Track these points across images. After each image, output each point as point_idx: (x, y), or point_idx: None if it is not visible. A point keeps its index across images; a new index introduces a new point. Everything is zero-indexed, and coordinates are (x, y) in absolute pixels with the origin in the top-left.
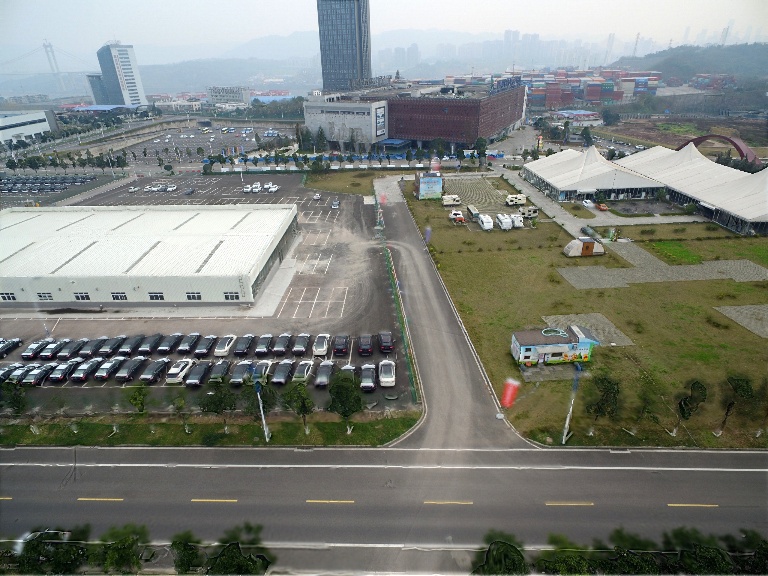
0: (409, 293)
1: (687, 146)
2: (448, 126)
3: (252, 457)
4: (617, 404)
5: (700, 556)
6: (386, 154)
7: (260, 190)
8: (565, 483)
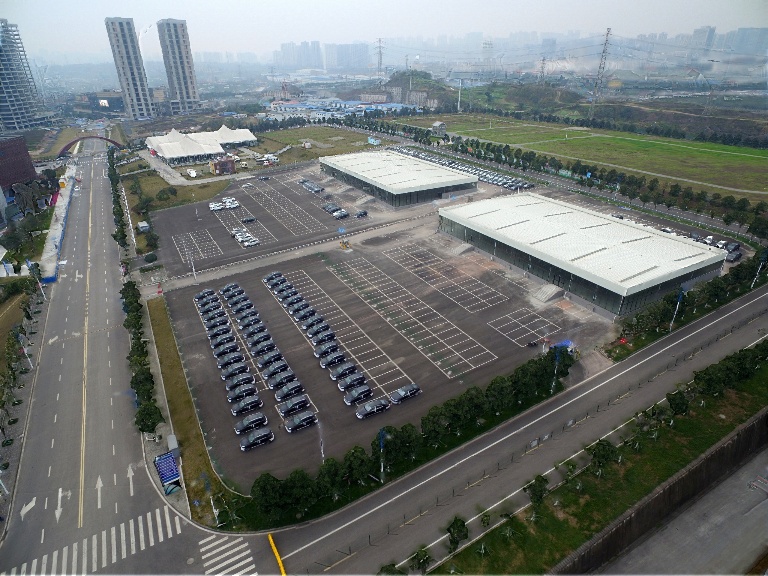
0: None
1: (174, 130)
2: (11, 170)
3: (429, 149)
4: None
5: (417, 128)
6: (16, 214)
7: None
8: (405, 141)
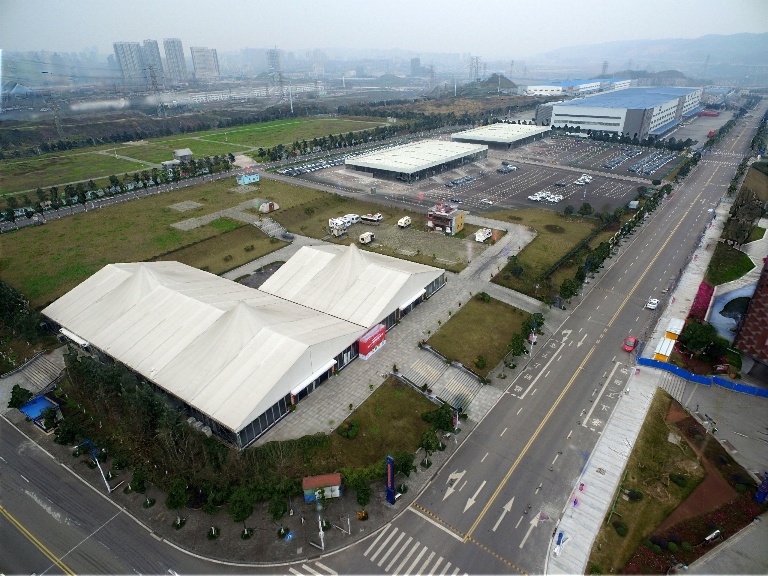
0: (311, 183)
1: None
2: None
3: None
4: (227, 181)
5: None
6: None
7: (541, 197)
8: None
